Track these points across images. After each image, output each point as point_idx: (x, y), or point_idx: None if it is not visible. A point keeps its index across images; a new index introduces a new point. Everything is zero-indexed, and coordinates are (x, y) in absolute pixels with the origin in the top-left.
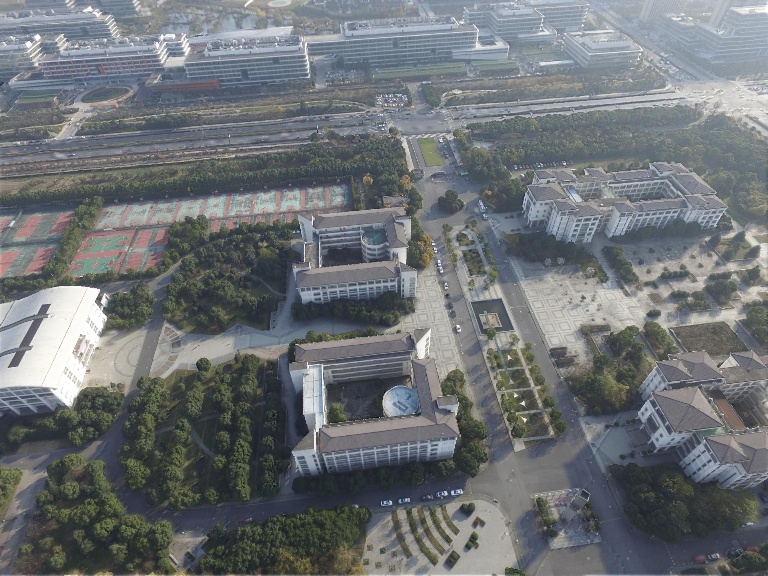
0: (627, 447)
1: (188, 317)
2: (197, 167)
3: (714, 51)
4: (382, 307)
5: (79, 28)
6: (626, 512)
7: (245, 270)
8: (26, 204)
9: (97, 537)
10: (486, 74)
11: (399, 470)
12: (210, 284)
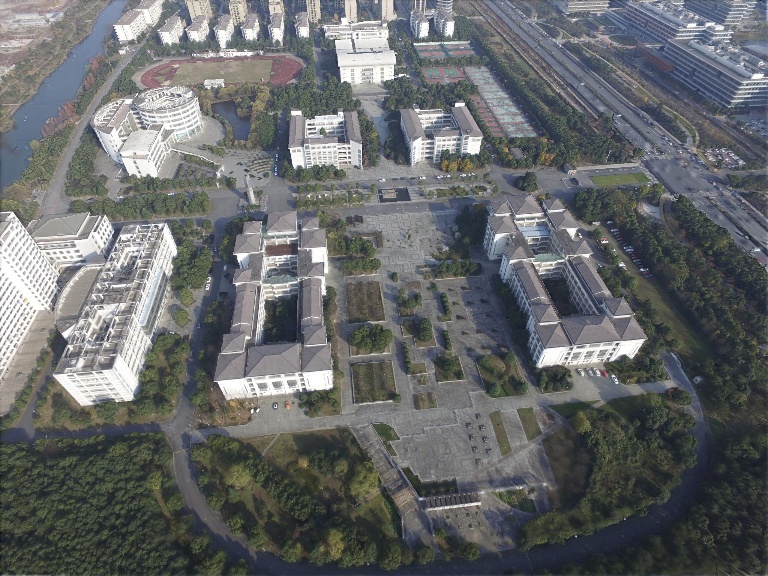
0: None
1: None
2: None
3: None
4: None
5: (714, 4)
6: None
7: None
8: None
9: None
10: None
11: None
12: None
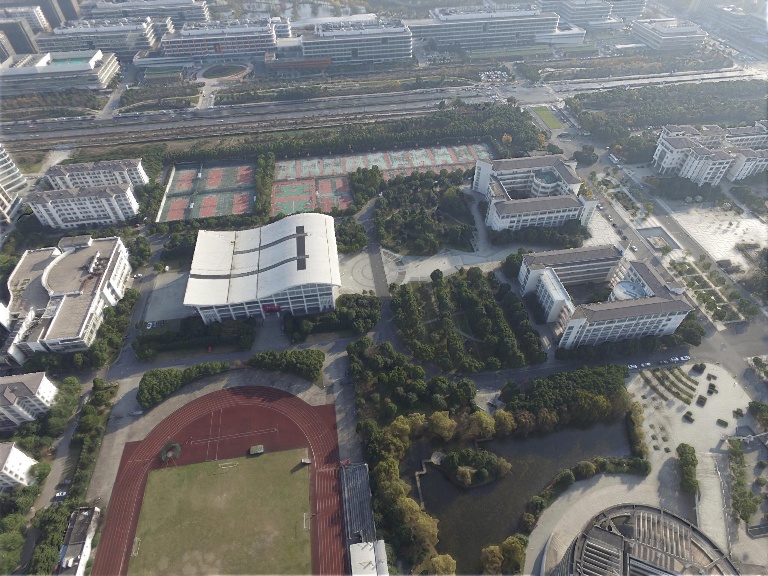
0: None
1: (400, 243)
2: None
3: None
4: (568, 232)
5: (177, 13)
6: None
7: (431, 208)
8: (205, 159)
9: (419, 390)
10: (572, 55)
11: (640, 341)
12: (412, 217)
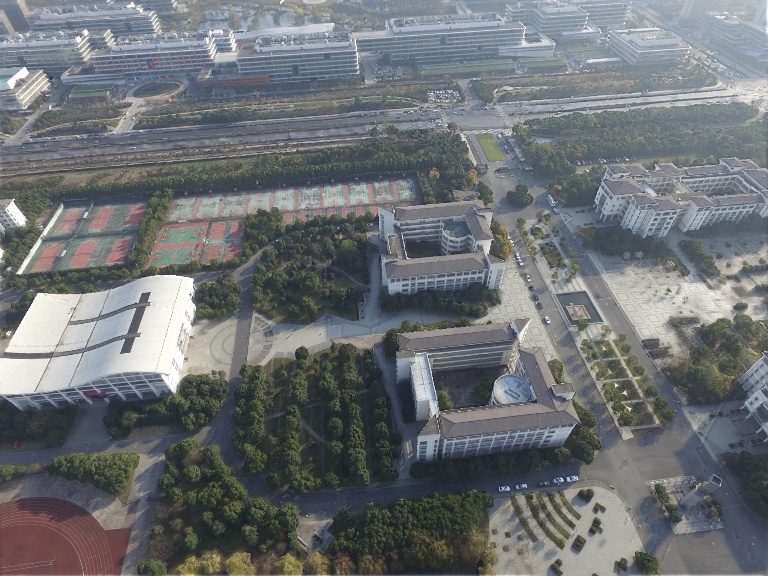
0: (735, 436)
1: (276, 307)
2: (261, 161)
3: (762, 49)
4: (470, 298)
5: (123, 24)
6: (747, 499)
7: (325, 262)
8: (97, 196)
9: (227, 519)
10: (535, 71)
11: (516, 456)
12: (296, 275)
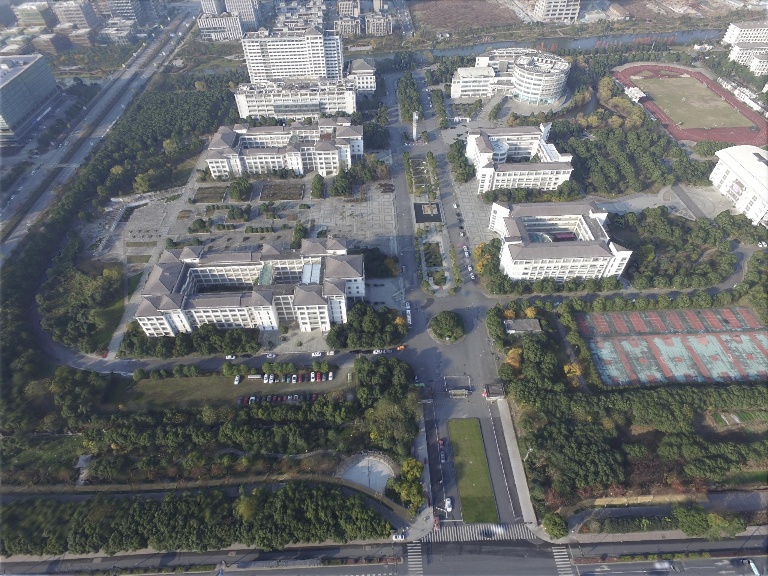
0: None
1: None
2: None
3: None
4: None
5: None
6: None
7: None
8: None
9: None
10: None
11: None
12: None
